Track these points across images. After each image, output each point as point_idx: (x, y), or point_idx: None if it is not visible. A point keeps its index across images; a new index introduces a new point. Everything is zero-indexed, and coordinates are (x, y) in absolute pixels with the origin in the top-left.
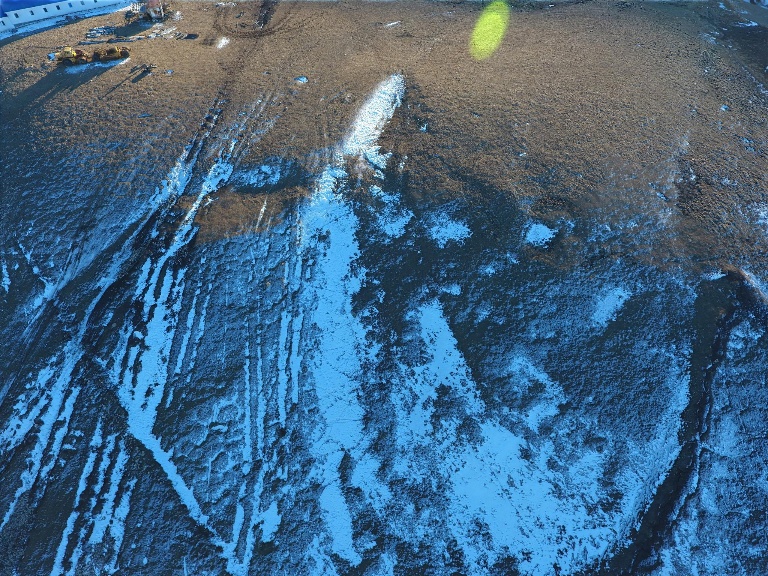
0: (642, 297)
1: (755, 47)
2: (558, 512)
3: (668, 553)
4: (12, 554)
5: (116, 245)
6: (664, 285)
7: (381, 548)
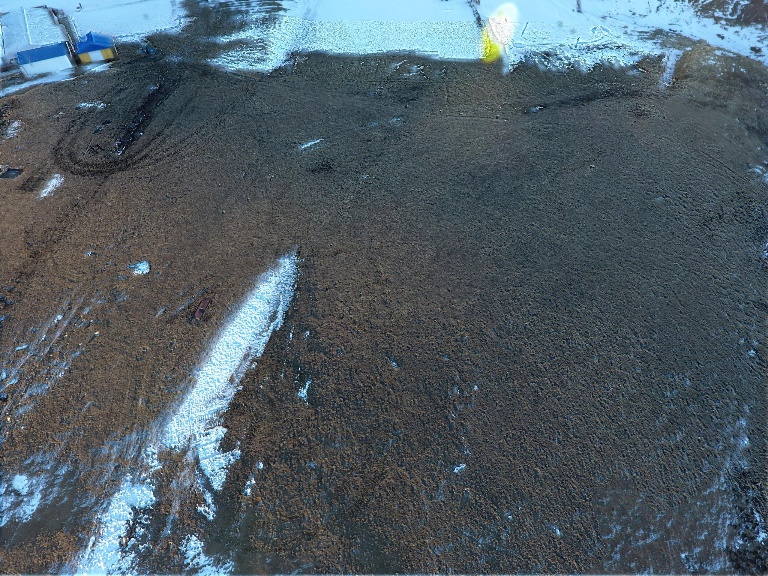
0: None
1: None
2: None
3: None
4: None
5: None
6: None
7: None
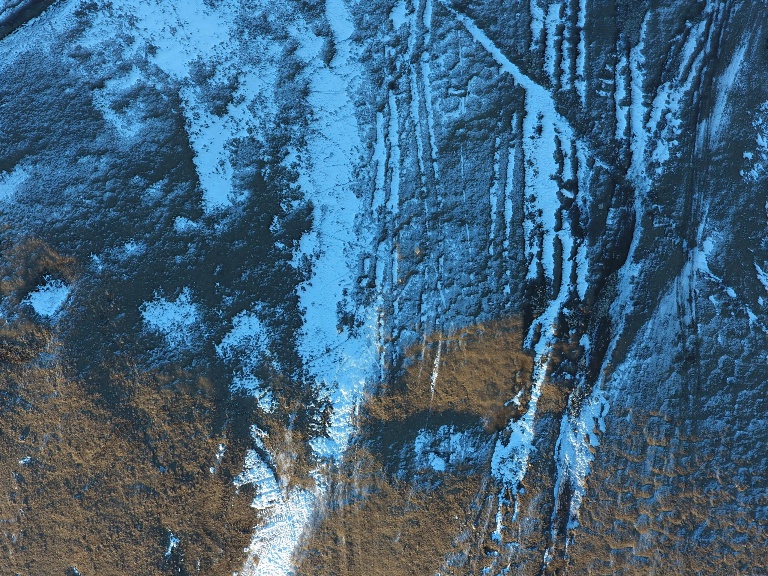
0: None
1: None
2: (138, 7)
3: None
4: (626, 0)
5: (635, 325)
6: None
7: None
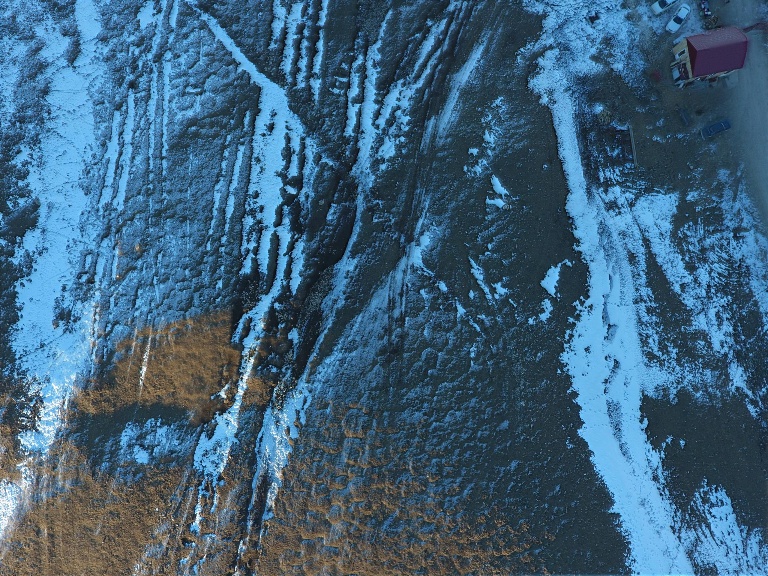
0: None
1: None
2: None
3: None
4: None
5: (344, 319)
6: None
7: None
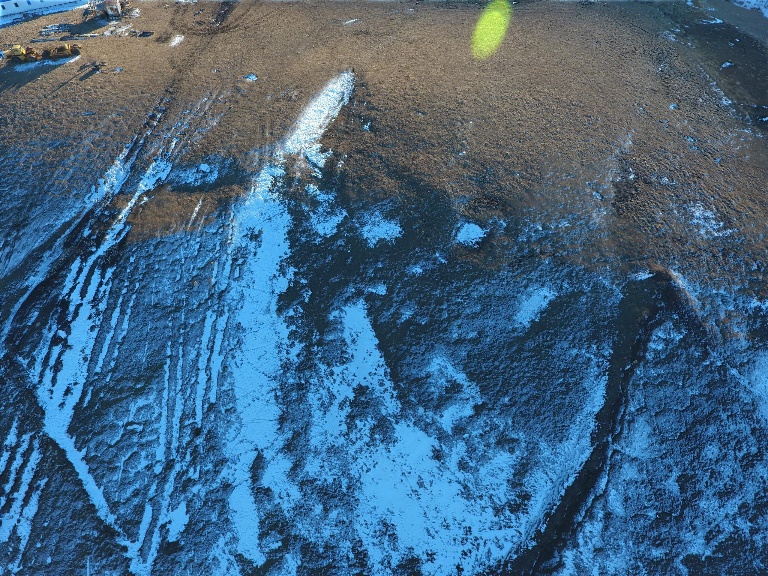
0: (567, 297)
1: (714, 45)
2: (465, 513)
3: (571, 555)
4: None
5: (47, 244)
6: (590, 285)
7: (286, 548)
